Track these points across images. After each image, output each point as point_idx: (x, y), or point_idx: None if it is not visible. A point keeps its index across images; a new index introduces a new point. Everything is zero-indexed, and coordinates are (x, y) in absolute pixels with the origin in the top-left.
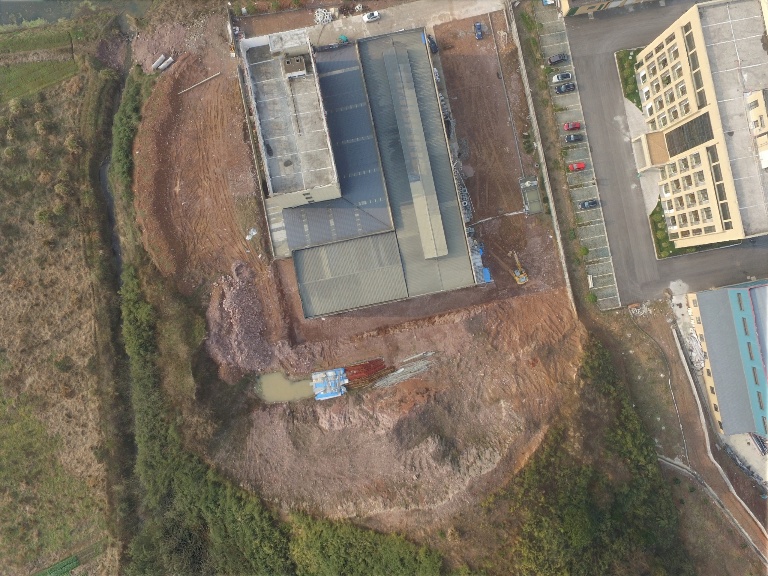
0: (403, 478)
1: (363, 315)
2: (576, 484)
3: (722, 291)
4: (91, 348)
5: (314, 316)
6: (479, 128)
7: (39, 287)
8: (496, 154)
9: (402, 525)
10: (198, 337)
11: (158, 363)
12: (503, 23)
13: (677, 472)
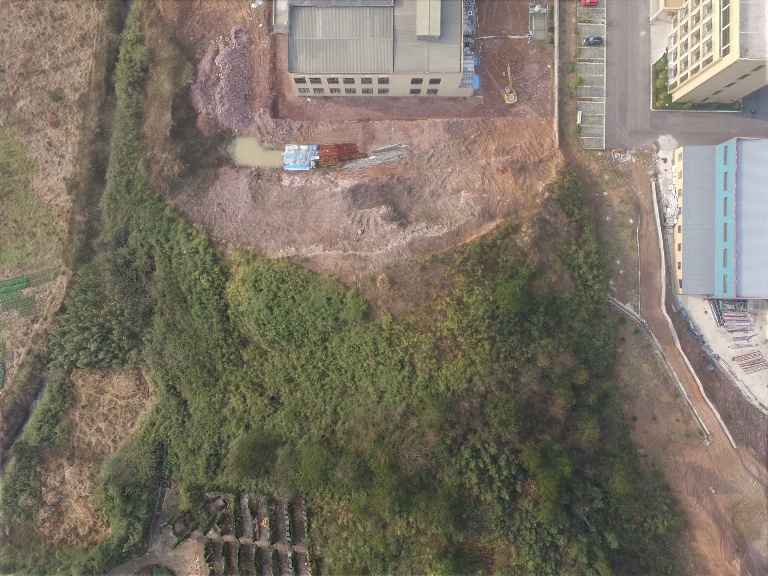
0: (348, 232)
1: (348, 104)
2: (517, 274)
3: (710, 147)
4: (84, 84)
5: (298, 73)
6: None
7: (49, 18)
8: None
9: (336, 269)
10: (184, 79)
11: (142, 103)
12: None
13: (625, 315)
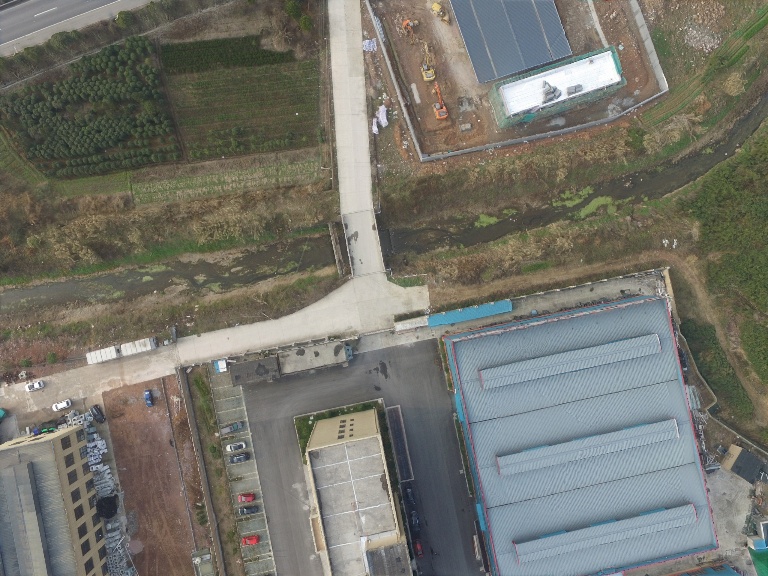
0: None
1: None
2: None
3: None
4: None
5: None
6: (149, 499)
7: None
8: (167, 526)
9: None
10: None
11: None
12: (177, 387)
13: None
